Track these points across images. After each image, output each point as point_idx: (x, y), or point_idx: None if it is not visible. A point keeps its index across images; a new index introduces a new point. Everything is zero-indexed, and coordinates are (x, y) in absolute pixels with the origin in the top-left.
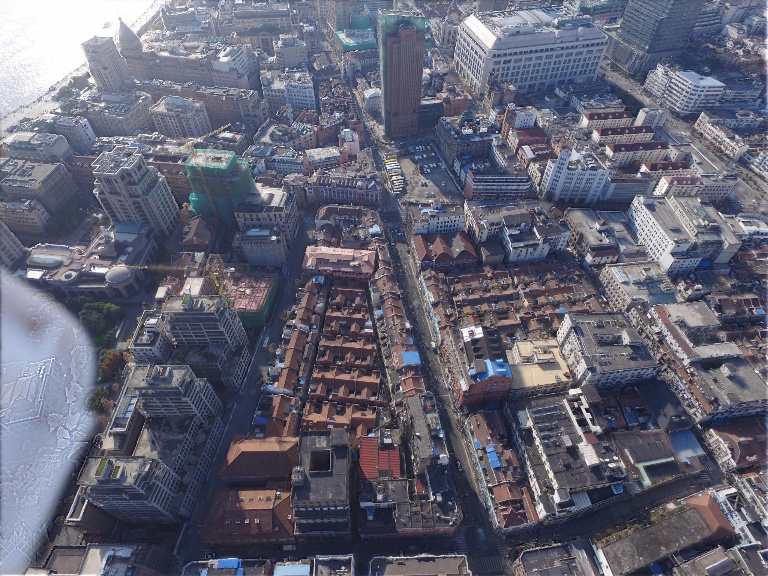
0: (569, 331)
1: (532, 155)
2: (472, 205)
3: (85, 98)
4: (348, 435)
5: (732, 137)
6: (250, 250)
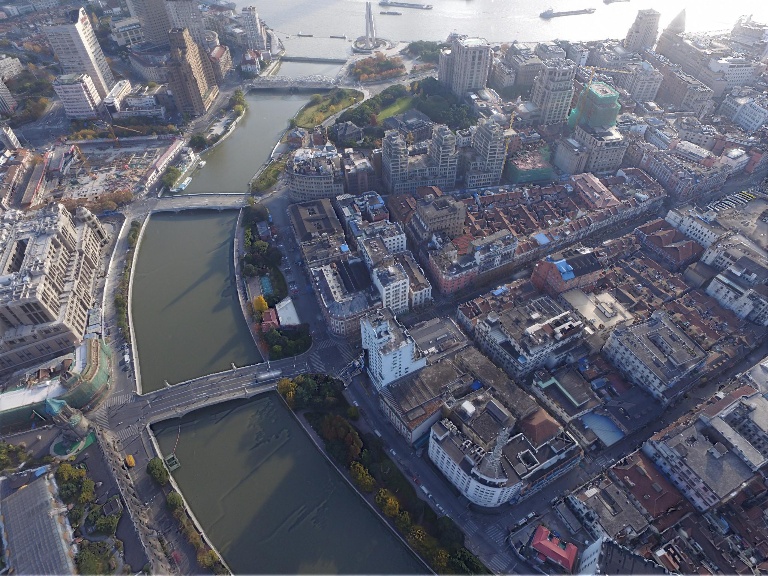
0: None
1: None
2: (737, 238)
3: (607, 44)
4: None
5: None
6: (560, 150)
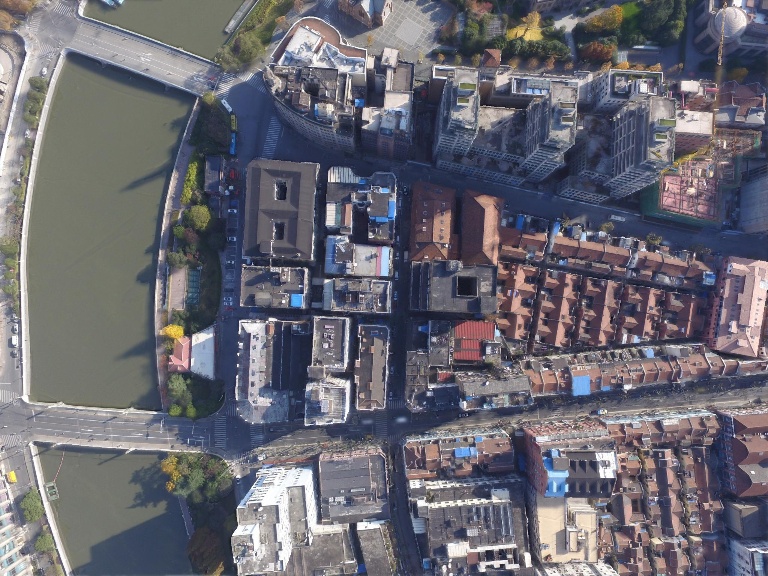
0: None
1: None
2: None
3: None
4: None
5: None
6: (766, 185)
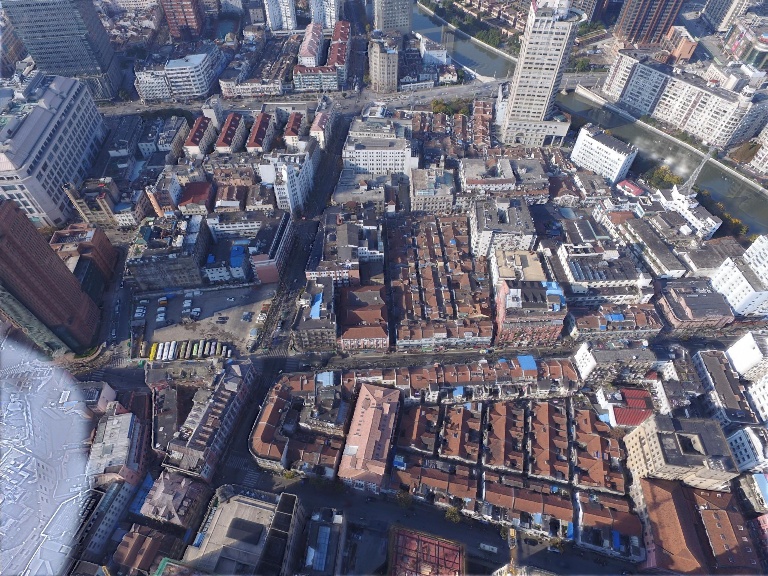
0: (491, 238)
1: (236, 202)
2: (317, 268)
3: None
4: (640, 424)
5: (262, 82)
6: None
